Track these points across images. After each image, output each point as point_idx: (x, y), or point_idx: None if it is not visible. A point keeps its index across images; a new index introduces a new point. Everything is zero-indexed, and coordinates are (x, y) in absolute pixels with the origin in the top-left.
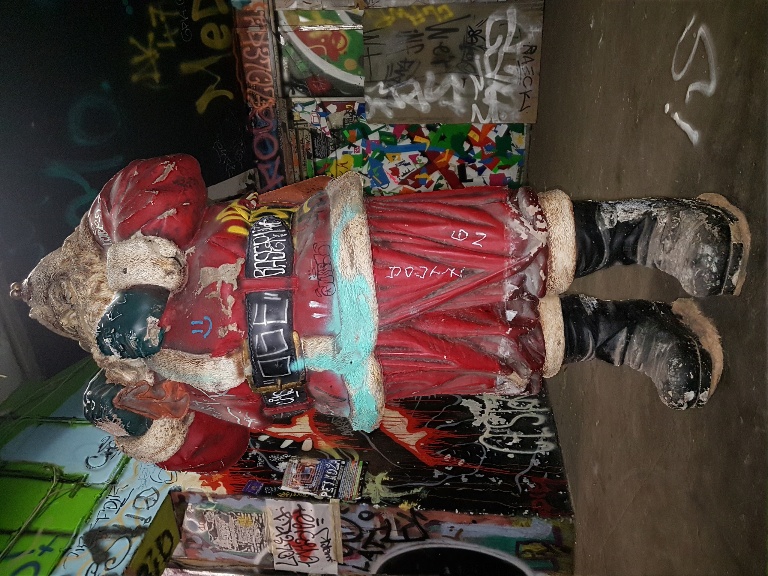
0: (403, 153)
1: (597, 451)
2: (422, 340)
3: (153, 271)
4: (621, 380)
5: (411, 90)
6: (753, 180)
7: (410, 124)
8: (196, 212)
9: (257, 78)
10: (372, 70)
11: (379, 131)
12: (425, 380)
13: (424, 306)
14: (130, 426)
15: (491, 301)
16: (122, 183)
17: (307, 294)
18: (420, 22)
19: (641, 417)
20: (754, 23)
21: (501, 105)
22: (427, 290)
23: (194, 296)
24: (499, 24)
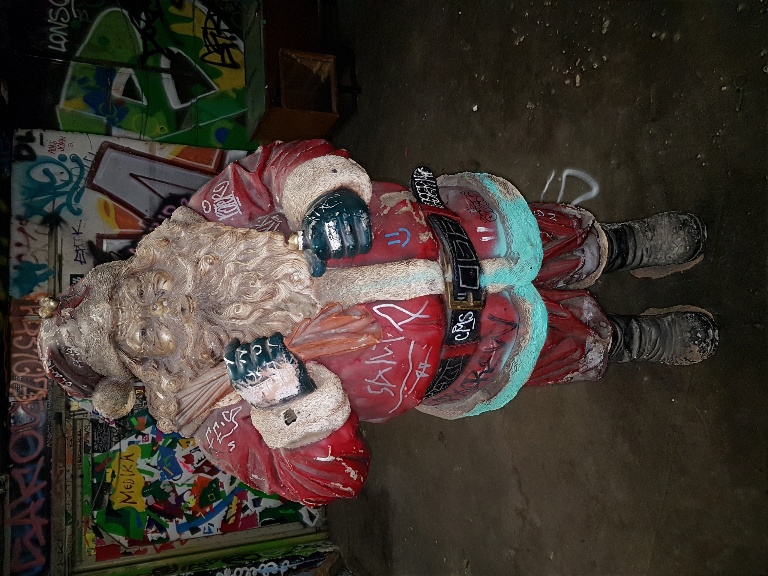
0: None
1: None
2: None
3: (363, 172)
4: (575, 473)
5: None
6: (670, 200)
7: None
8: None
9: (26, 368)
10: None
11: None
12: None
13: None
14: (303, 376)
15: (572, 265)
16: (265, 150)
17: (473, 222)
18: None
19: (623, 470)
20: (620, 136)
21: None
22: None
23: (381, 216)
24: None
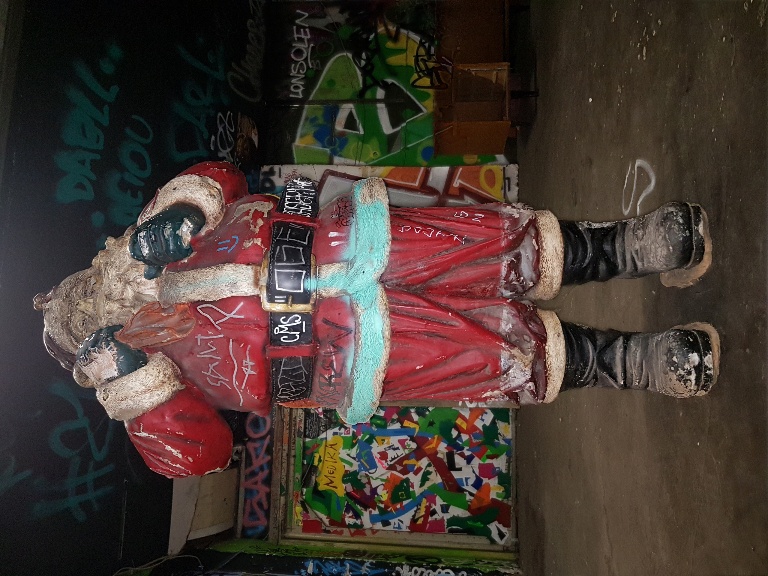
0: (392, 437)
1: None
2: (428, 300)
3: (199, 188)
4: (638, 523)
5: None
6: (697, 188)
7: (400, 408)
8: (240, 183)
9: None
10: None
11: None
12: (430, 348)
13: (430, 263)
14: (122, 361)
15: (491, 270)
16: None
17: (328, 227)
18: None
19: (666, 527)
20: (668, 114)
21: None
22: (433, 249)
23: (226, 226)
24: None
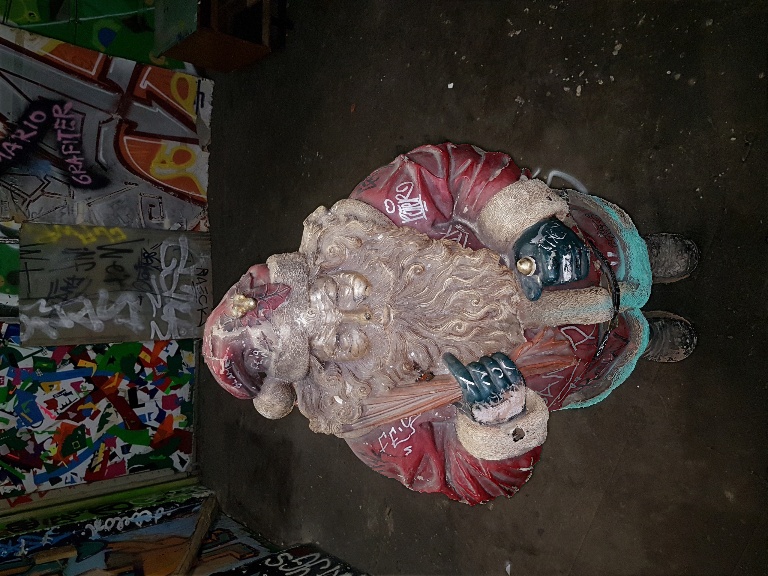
0: (63, 381)
1: (503, 530)
2: None
3: None
4: None
5: (81, 308)
6: (662, 221)
7: (76, 346)
8: None
9: None
10: (31, 286)
11: (33, 357)
12: None
13: None
14: None
15: None
16: (444, 153)
17: (604, 247)
18: (90, 241)
19: (579, 440)
20: (618, 154)
21: (180, 321)
22: None
23: None
24: (173, 249)
